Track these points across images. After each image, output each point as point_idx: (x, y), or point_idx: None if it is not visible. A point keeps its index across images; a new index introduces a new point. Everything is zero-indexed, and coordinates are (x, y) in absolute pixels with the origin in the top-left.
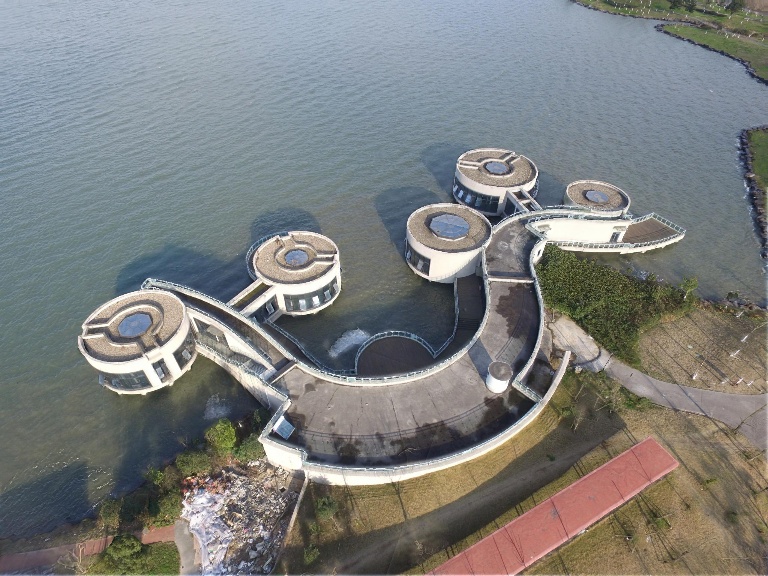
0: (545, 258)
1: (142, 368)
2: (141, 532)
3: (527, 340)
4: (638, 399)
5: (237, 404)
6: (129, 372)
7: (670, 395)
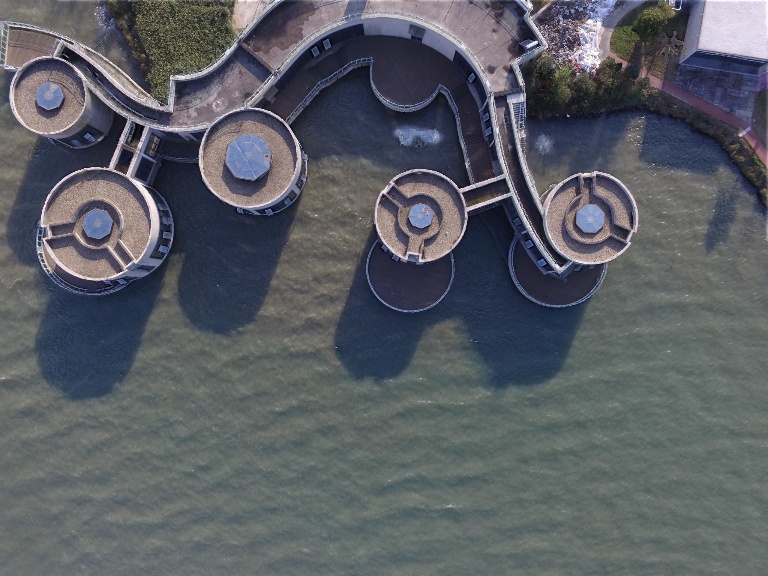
0: None
1: None
2: None
3: None
4: None
5: (529, 137)
6: None
7: None
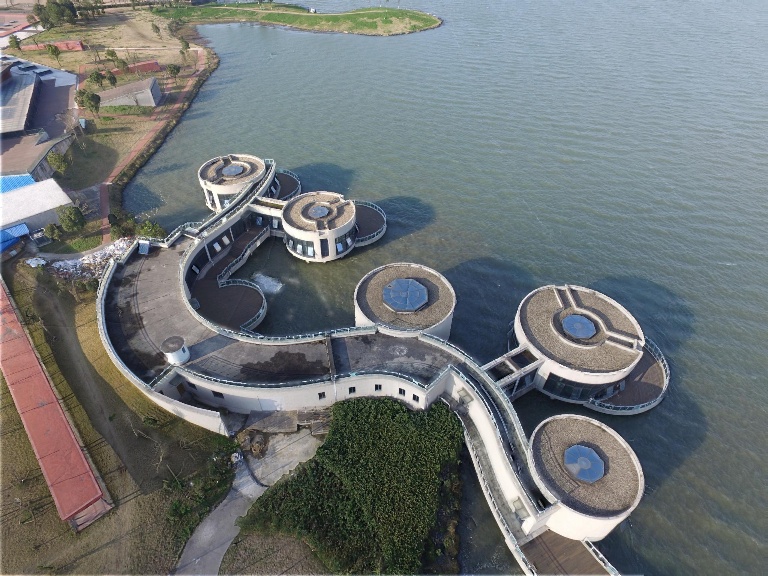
0: (418, 412)
1: None
2: None
3: (238, 380)
4: None
5: None
6: None
7: (197, 568)
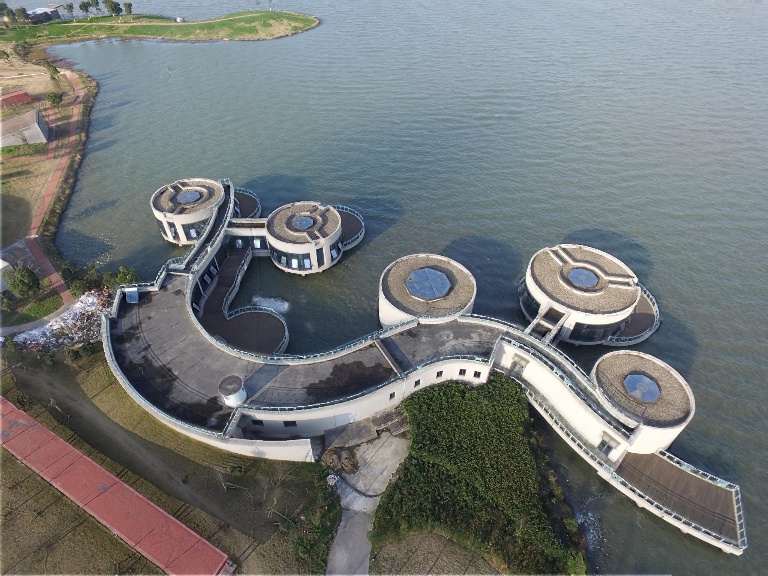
0: (483, 386)
1: (162, 220)
2: (67, 290)
3: (309, 403)
4: None
5: None
6: (157, 218)
7: None
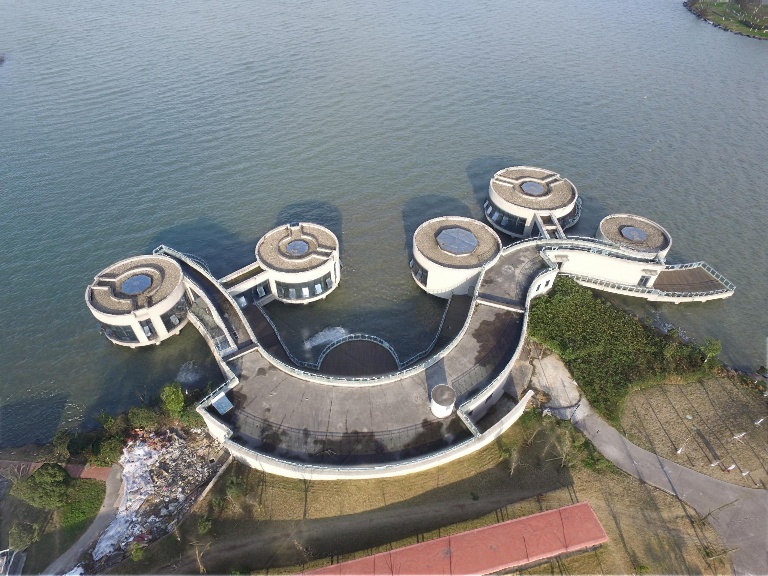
0: (554, 290)
1: (130, 323)
2: (84, 466)
3: (493, 370)
4: (597, 459)
5: (207, 374)
6: (119, 325)
7: (642, 464)
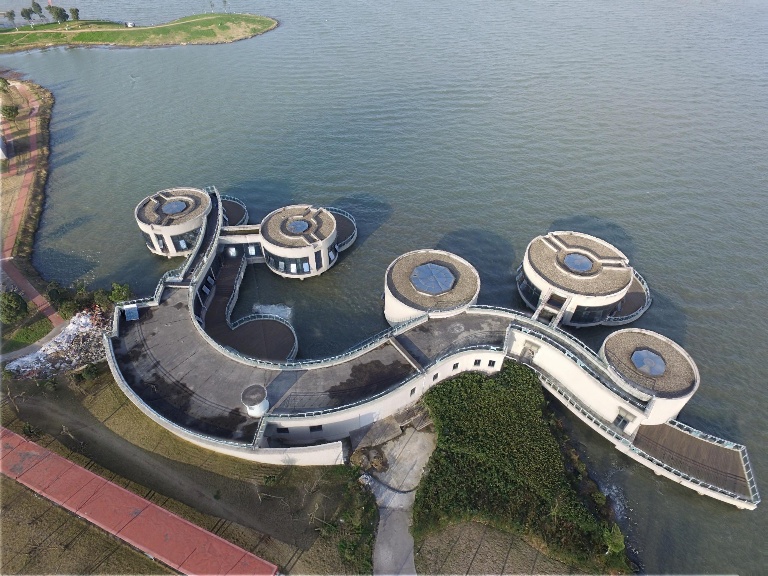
0: (498, 374)
1: (149, 233)
2: (55, 312)
3: (334, 406)
4: None
5: None
6: (144, 231)
7: None
